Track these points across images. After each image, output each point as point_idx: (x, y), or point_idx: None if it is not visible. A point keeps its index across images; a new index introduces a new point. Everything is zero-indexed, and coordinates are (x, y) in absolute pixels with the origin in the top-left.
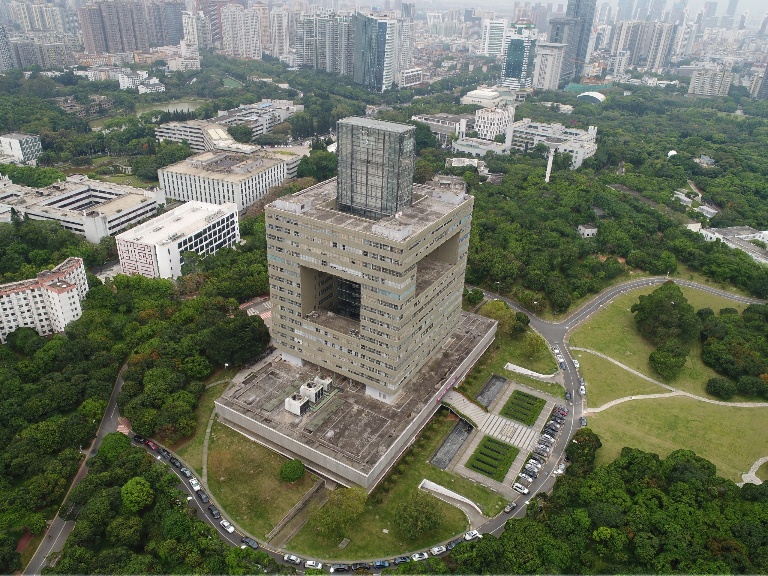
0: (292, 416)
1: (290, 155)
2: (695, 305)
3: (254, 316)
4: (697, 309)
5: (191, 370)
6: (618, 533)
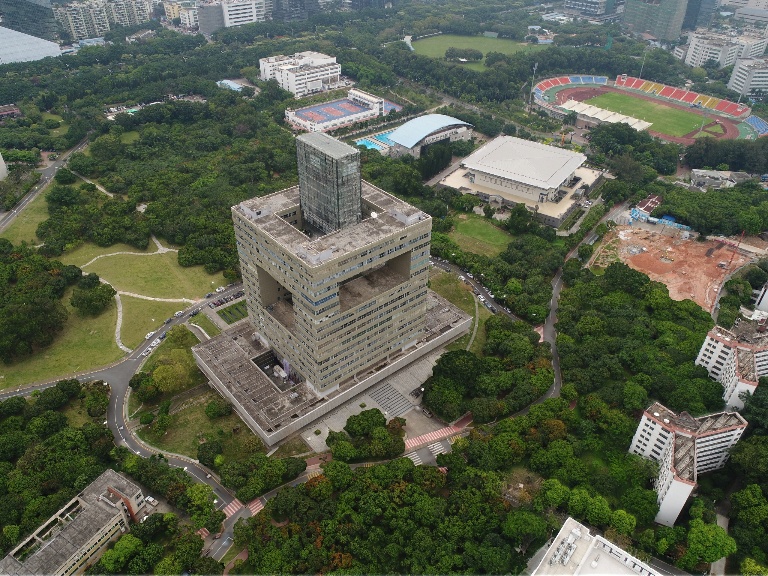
0: None
1: None
2: None
3: (437, 397)
4: None
5: None
6: None
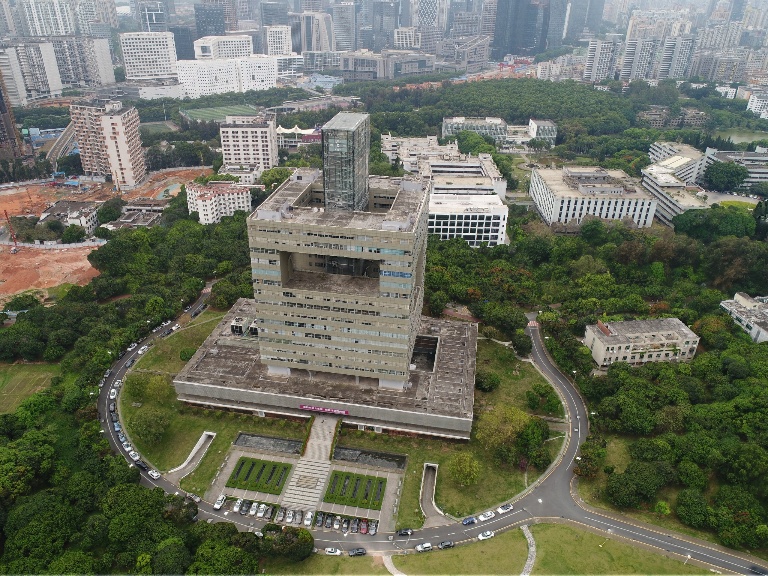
0: None
1: (702, 202)
2: None
3: None
4: None
5: None
6: (146, 575)
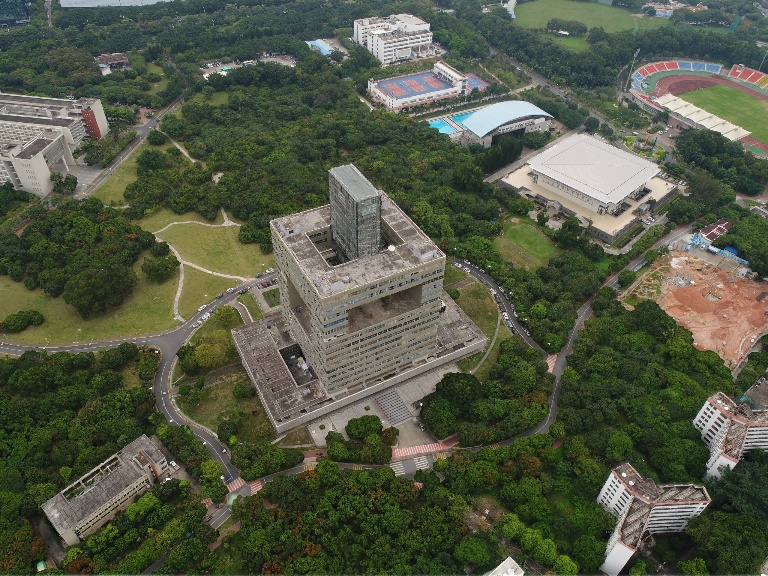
0: None
1: None
2: (27, 306)
3: (431, 415)
4: (34, 303)
5: None
6: None
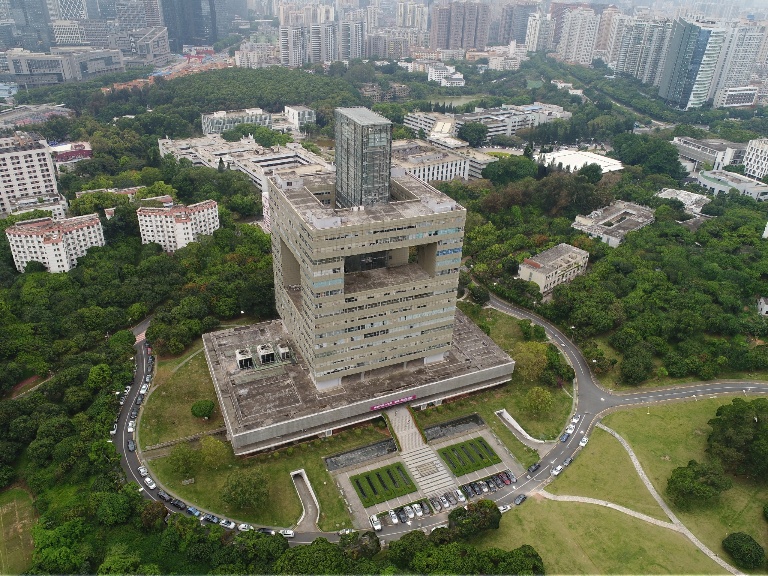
0: (236, 367)
1: (490, 156)
2: None
3: None
4: None
5: (219, 308)
6: None
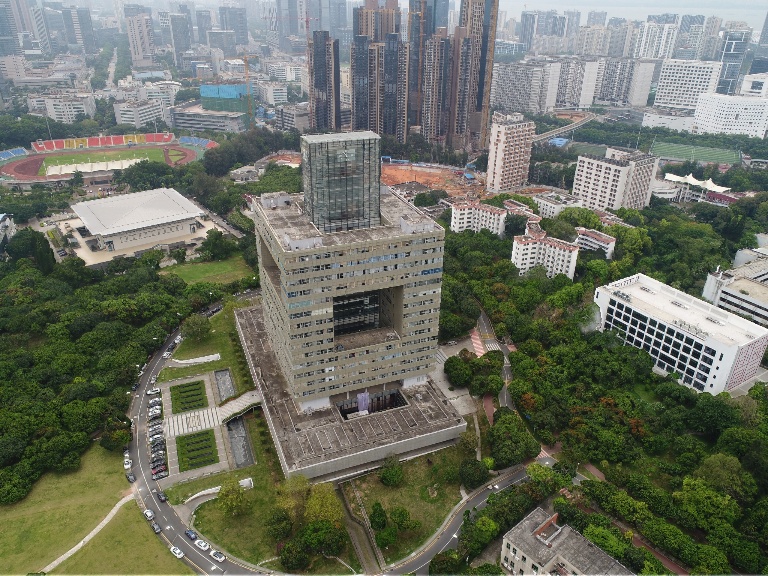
0: None
1: None
2: None
3: (454, 323)
4: None
5: None
6: None
